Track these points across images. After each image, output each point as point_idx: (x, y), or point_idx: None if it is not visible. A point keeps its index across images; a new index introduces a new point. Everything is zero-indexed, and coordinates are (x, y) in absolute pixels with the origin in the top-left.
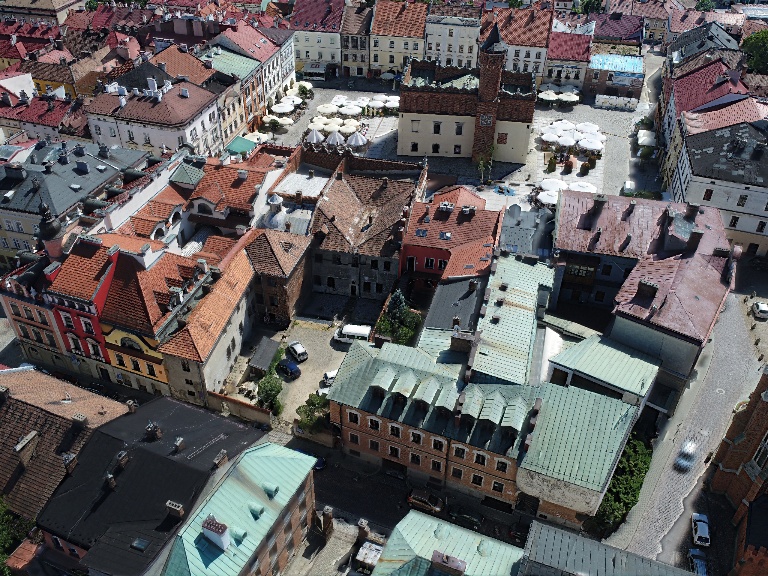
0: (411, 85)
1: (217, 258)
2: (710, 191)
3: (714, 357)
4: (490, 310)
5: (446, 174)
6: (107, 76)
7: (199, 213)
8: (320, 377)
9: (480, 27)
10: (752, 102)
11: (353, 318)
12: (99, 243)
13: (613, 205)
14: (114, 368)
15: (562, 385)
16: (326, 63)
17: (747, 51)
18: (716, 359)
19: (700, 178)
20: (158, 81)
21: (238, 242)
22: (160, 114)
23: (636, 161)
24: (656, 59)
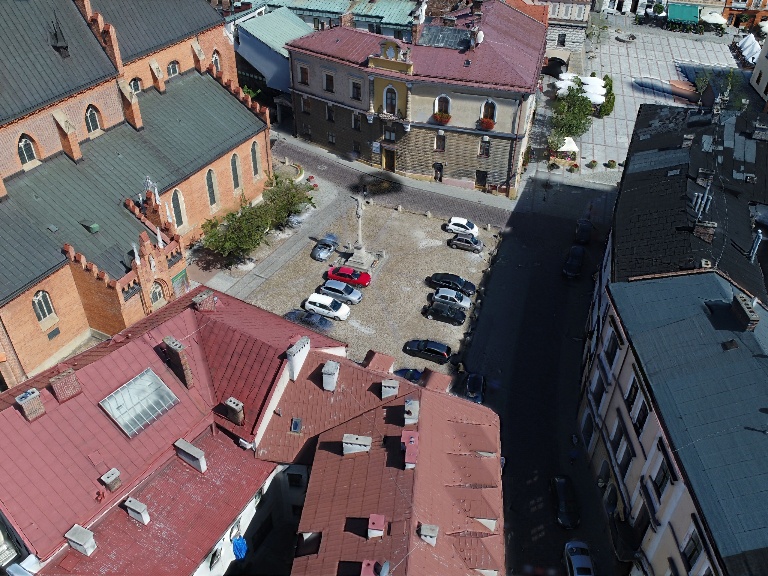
0: None
1: None
2: None
3: (375, 177)
4: None
5: None
6: None
7: None
8: None
9: None
10: None
11: None
12: None
13: (483, 15)
14: None
15: None
16: None
17: None
18: (371, 178)
19: None
20: None
21: None
22: None
23: None
24: None
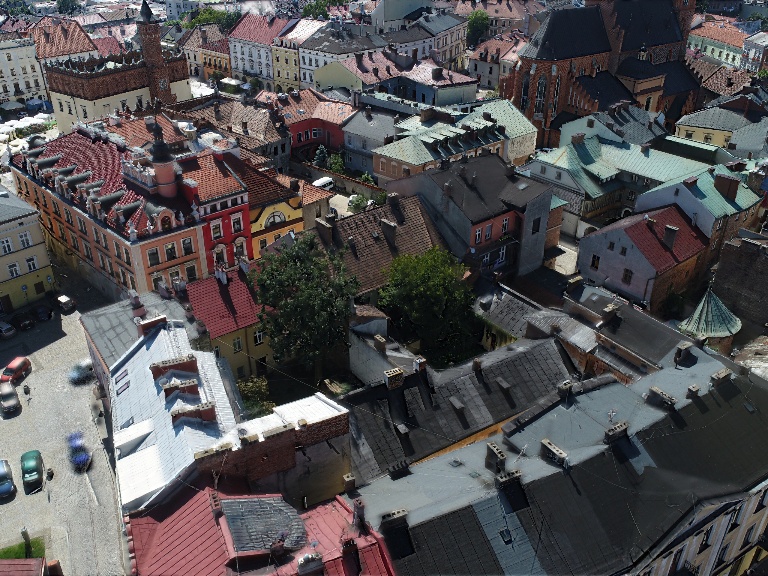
0: (94, 72)
1: None
2: None
3: None
4: None
5: None
6: None
7: None
8: (345, 209)
9: (35, 45)
10: (307, 20)
11: None
12: None
13: None
14: None
15: None
16: None
17: None
18: None
19: (342, 55)
20: None
21: None
22: None
23: None
24: None
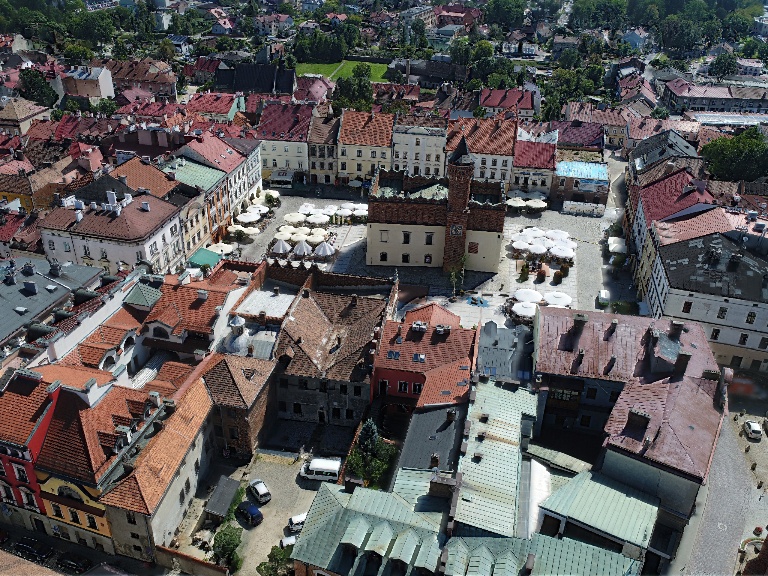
0: (379, 196)
1: (172, 388)
2: (689, 303)
3: (711, 485)
4: (471, 446)
5: (417, 284)
6: (65, 189)
7: (154, 337)
8: (284, 522)
9: (446, 137)
10: (721, 212)
11: (321, 448)
12: (38, 378)
13: (594, 324)
14: (50, 519)
15: (554, 533)
16: (293, 171)
17: (706, 158)
18: (713, 488)
19: (678, 290)
20: (118, 194)
21: (196, 369)
22: (118, 229)
23: (608, 268)
24: (618, 164)
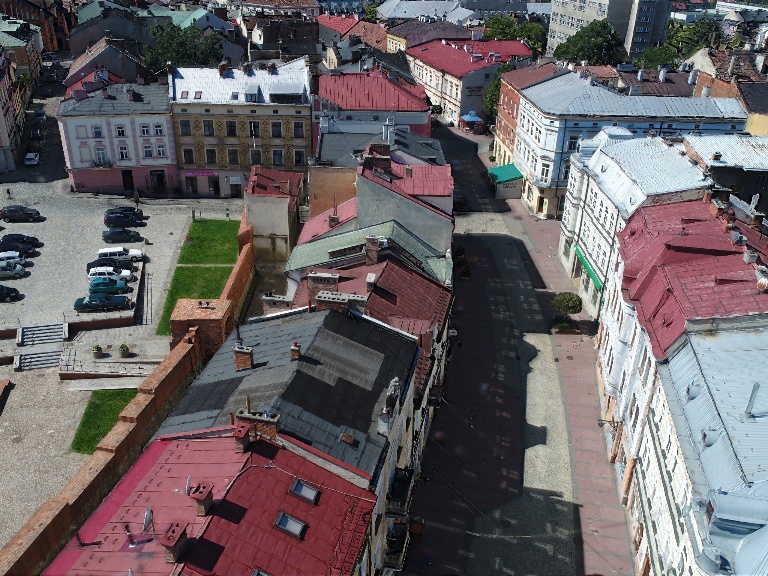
0: None
1: None
2: None
3: None
4: None
5: None
6: None
7: None
8: None
9: None
10: None
11: None
12: None
13: None
14: None
15: None
16: None
17: None
18: None
19: None
20: None
21: None
22: None
23: None
24: None
